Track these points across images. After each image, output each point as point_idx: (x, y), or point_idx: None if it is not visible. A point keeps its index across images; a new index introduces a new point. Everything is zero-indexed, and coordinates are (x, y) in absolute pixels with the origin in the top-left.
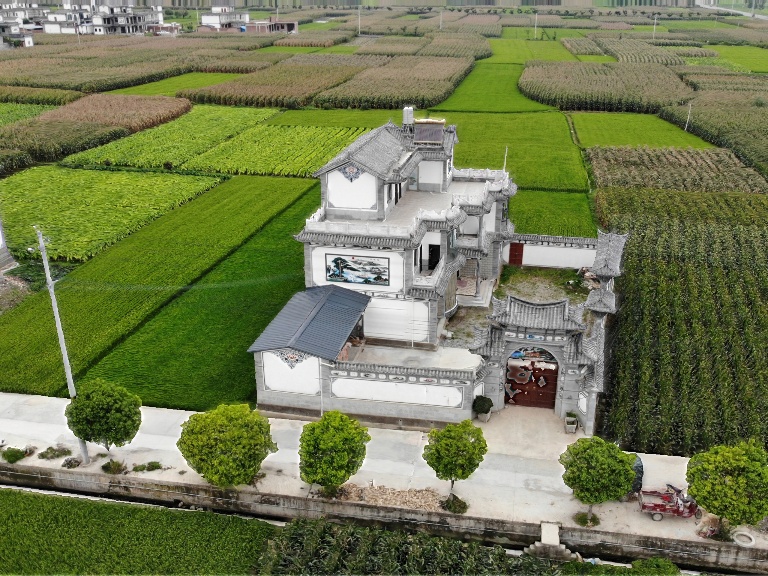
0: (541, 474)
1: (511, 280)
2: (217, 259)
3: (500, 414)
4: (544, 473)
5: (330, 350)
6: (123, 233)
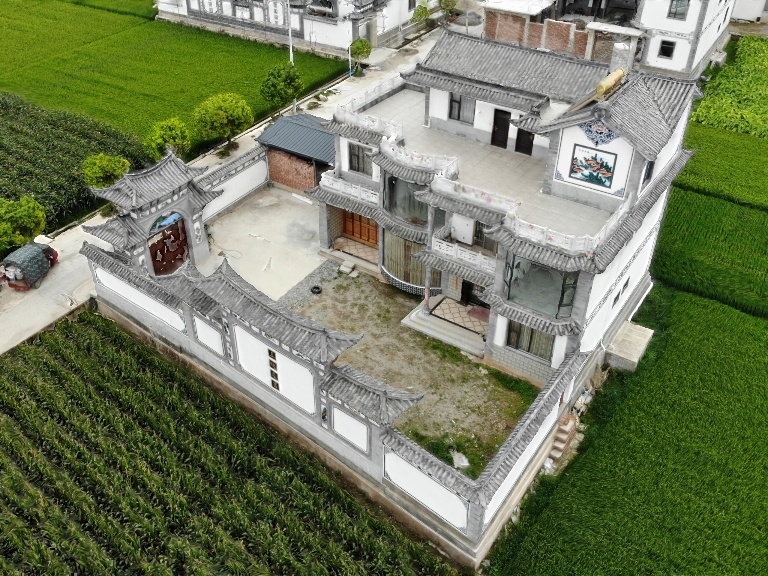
0: None
1: (504, 391)
2: (674, 180)
3: (179, 257)
4: None
5: (270, 138)
6: None
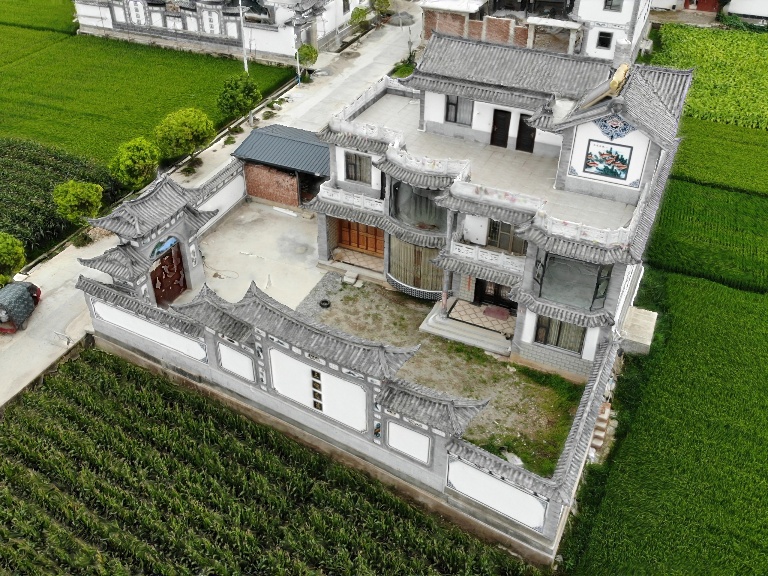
0: (80, 292)
1: (536, 386)
2: None
3: None
4: (80, 294)
5: (247, 151)
6: (720, 117)
